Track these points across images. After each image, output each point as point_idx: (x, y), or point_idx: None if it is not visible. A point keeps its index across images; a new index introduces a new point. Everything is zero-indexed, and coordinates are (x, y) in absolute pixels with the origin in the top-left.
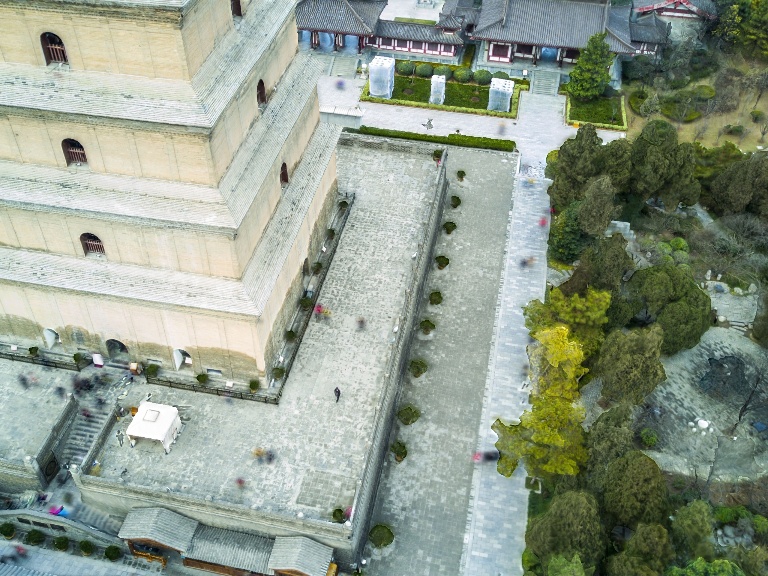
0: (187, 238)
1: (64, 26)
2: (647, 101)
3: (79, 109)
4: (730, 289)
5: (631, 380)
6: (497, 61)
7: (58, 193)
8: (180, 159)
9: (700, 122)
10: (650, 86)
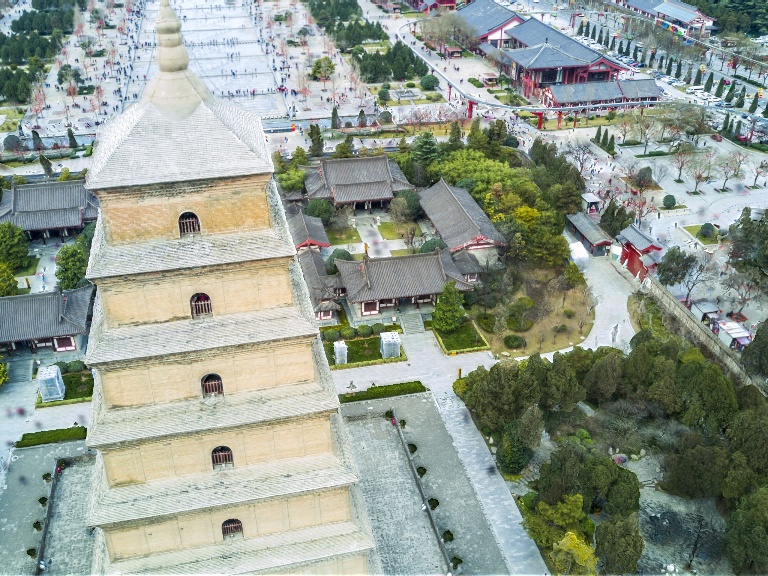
0: (328, 566)
1: (235, 439)
2: (498, 323)
3: (251, 496)
4: (629, 457)
5: (628, 556)
6: (369, 315)
7: (221, 565)
8: (324, 508)
9: (534, 328)
10: (487, 307)
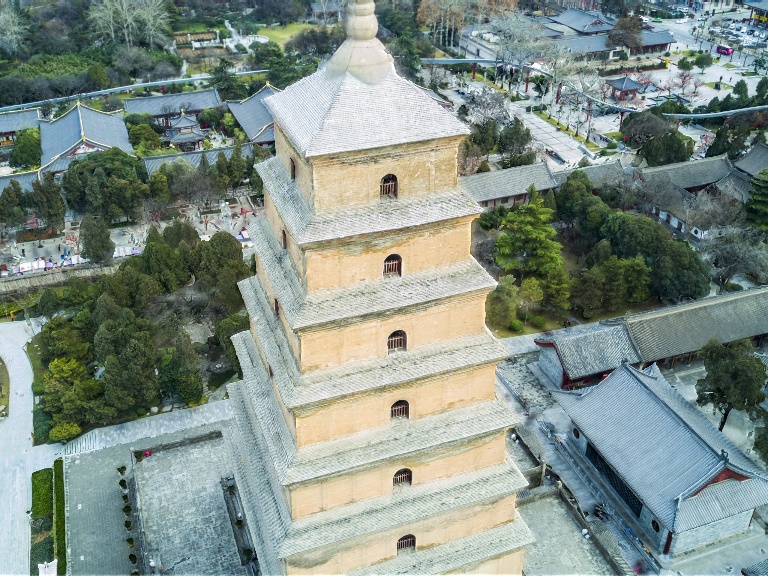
0: None
1: None
2: None
3: None
4: None
5: None
6: None
7: None
8: None
9: None
10: None
